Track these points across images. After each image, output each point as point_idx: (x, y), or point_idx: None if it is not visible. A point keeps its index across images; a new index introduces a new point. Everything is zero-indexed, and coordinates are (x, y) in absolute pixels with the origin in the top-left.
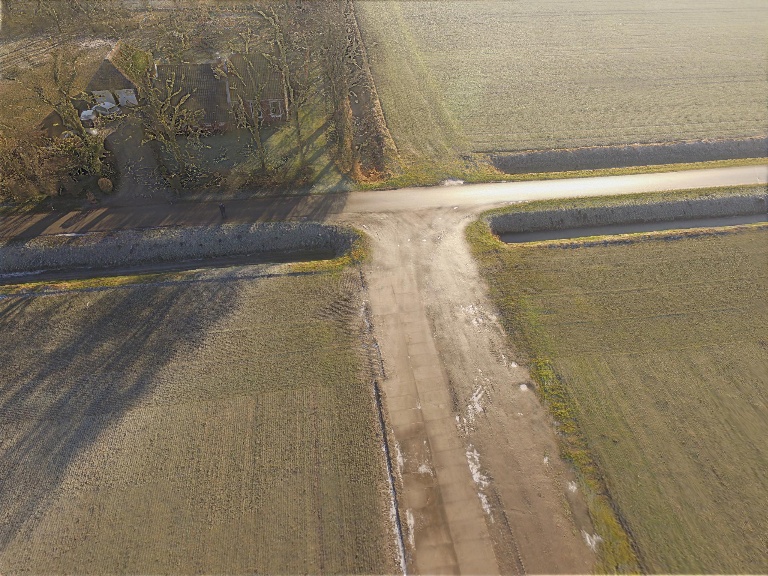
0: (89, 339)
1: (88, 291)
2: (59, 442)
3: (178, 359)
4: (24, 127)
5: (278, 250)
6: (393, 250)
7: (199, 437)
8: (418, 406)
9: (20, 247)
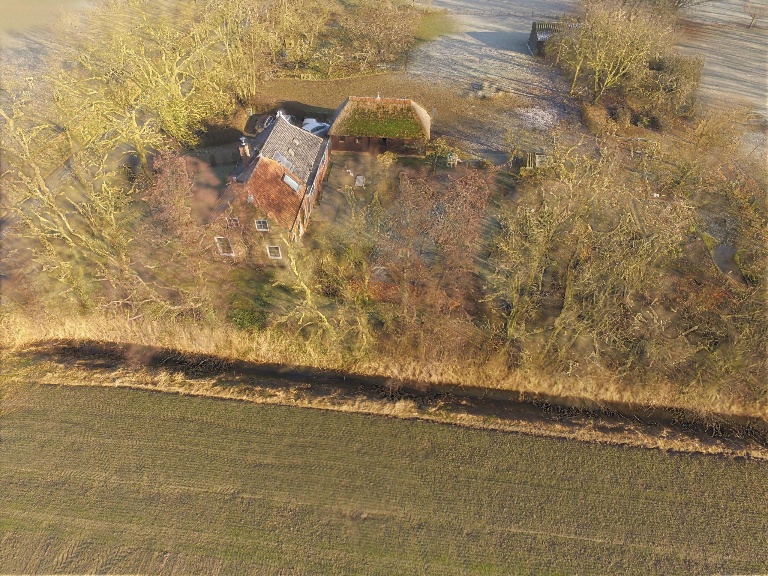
0: None
1: None
2: None
3: None
4: (318, 102)
5: None
6: None
7: None
8: None
9: None
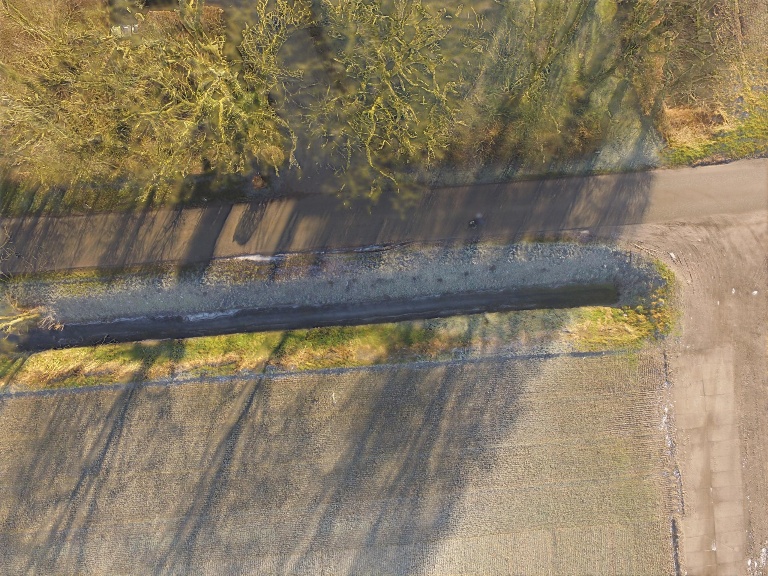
0: (356, 451)
1: (325, 373)
2: (375, 571)
3: (464, 484)
4: None
5: (542, 284)
6: (710, 313)
7: (505, 572)
8: (713, 548)
9: (197, 283)
